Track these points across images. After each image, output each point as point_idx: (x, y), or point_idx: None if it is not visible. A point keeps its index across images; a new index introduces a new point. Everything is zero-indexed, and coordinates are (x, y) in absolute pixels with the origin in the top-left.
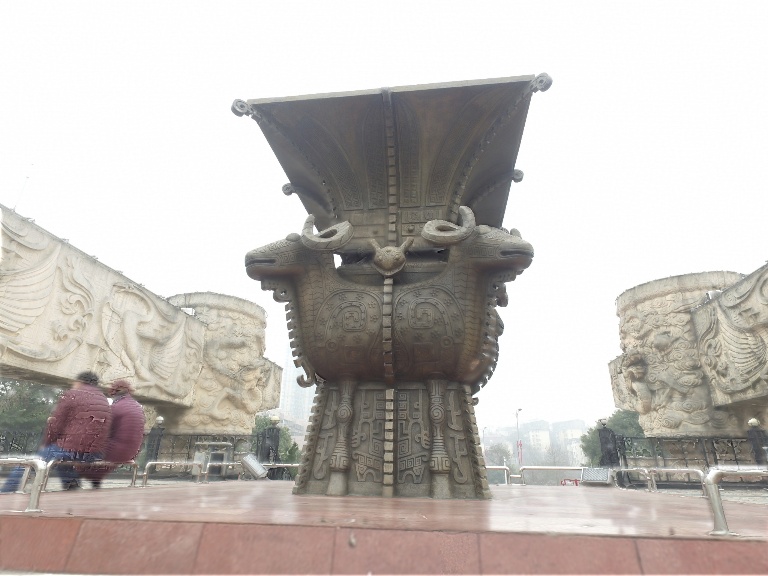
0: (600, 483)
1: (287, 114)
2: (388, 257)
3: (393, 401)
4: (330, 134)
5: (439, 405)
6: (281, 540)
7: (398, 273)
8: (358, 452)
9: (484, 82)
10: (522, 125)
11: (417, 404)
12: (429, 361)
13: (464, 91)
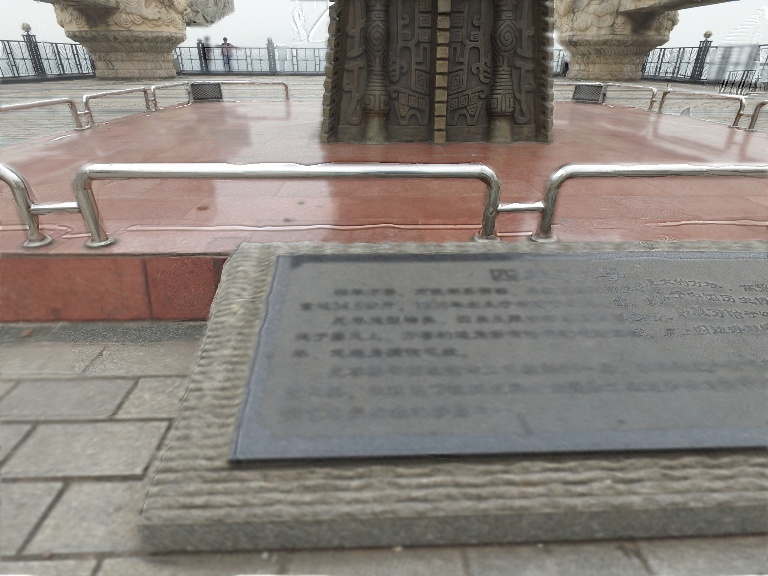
0: None
1: None
2: None
3: None
4: None
5: None
6: None
7: None
8: None
9: None
10: None
11: None
12: None
13: None
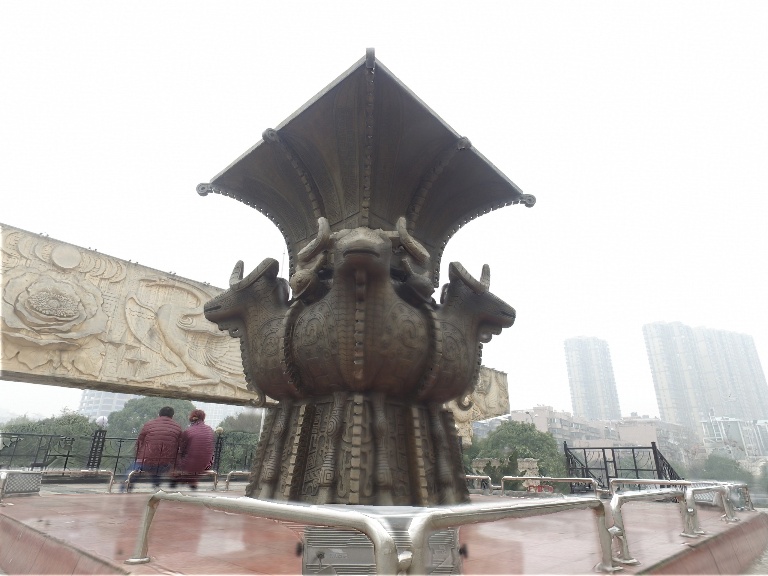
0: (704, 504)
1: (233, 181)
2: (293, 282)
3: (304, 416)
4: (265, 183)
5: (334, 417)
6: (9, 531)
7: (305, 294)
8: (284, 465)
9: (332, 86)
10: (410, 100)
11: (326, 417)
12: (322, 375)
13: (324, 102)
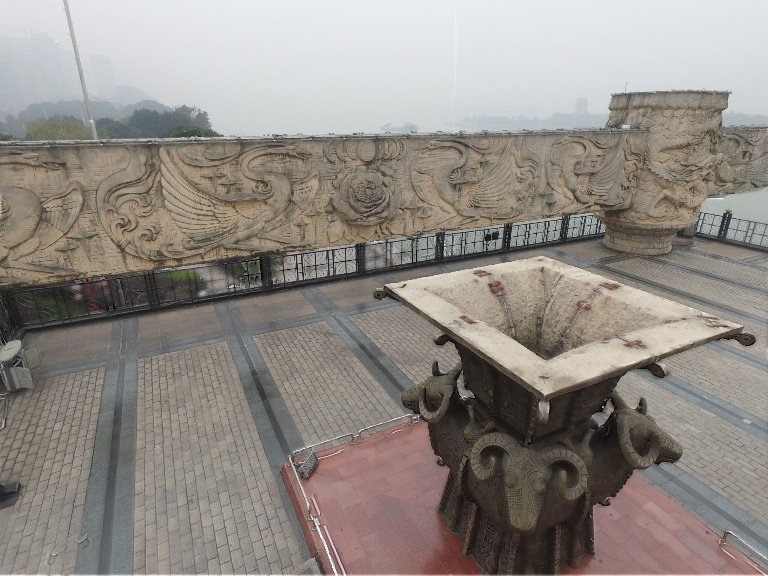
0: None
1: None
2: None
3: None
4: None
5: None
6: None
7: None
8: None
9: None
10: None
11: None
12: None
13: None
